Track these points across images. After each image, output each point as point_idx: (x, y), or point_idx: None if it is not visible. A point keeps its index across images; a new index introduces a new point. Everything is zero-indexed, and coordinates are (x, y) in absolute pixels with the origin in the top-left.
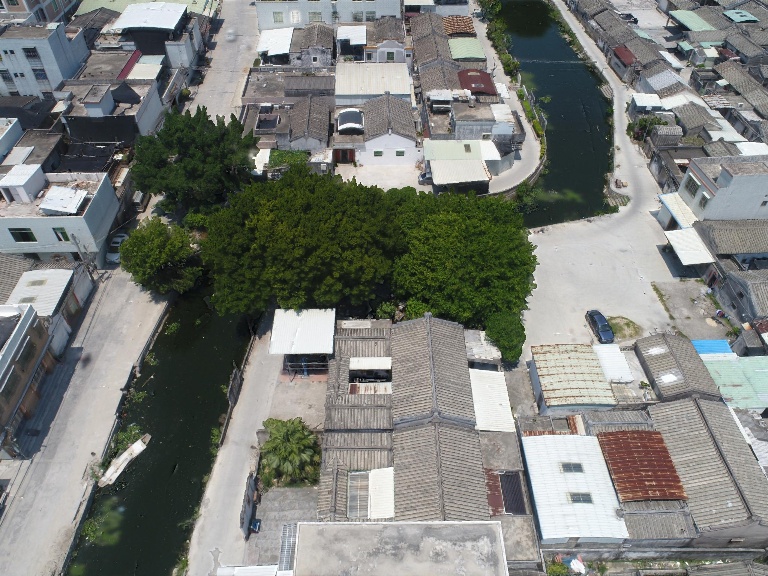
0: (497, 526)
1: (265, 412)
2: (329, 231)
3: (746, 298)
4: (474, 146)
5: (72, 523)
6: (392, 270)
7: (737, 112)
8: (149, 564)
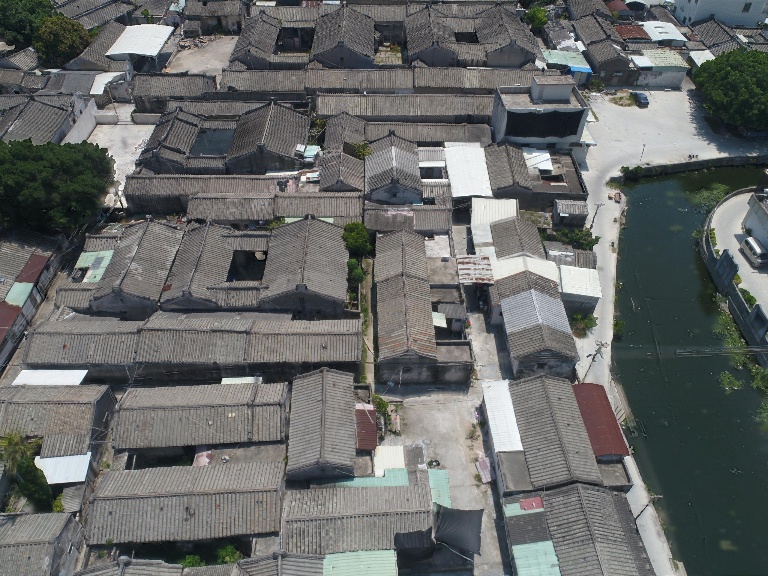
0: None
1: None
2: None
3: None
4: None
5: None
6: None
7: None
8: None
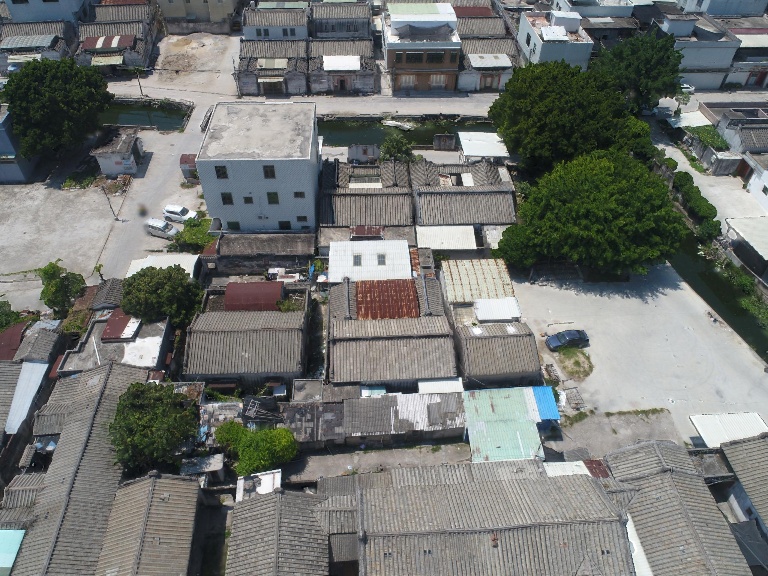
0: None
1: (433, 161)
2: (537, 94)
3: None
4: None
5: (358, 114)
6: None
7: None
8: (339, 140)
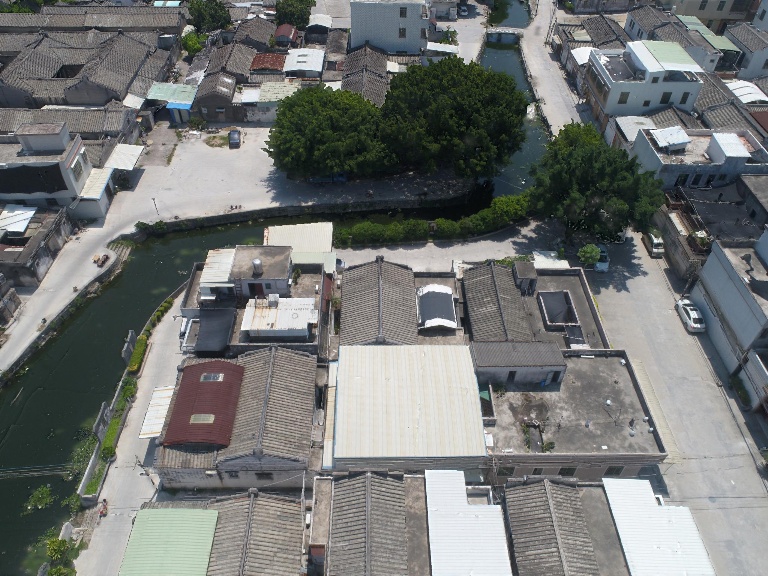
0: None
1: None
2: None
3: None
4: None
5: None
6: None
7: None
8: None
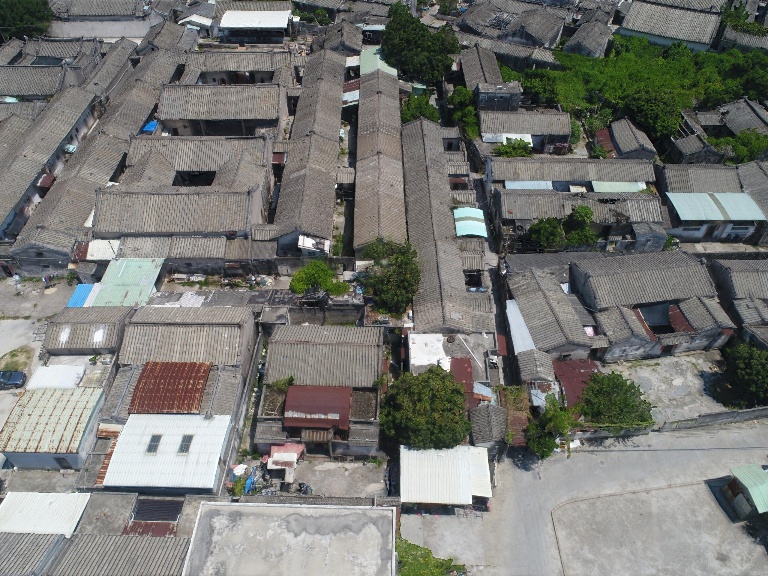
0: (205, 506)
1: None
2: None
3: (46, 252)
4: None
5: None
6: None
7: None
8: None
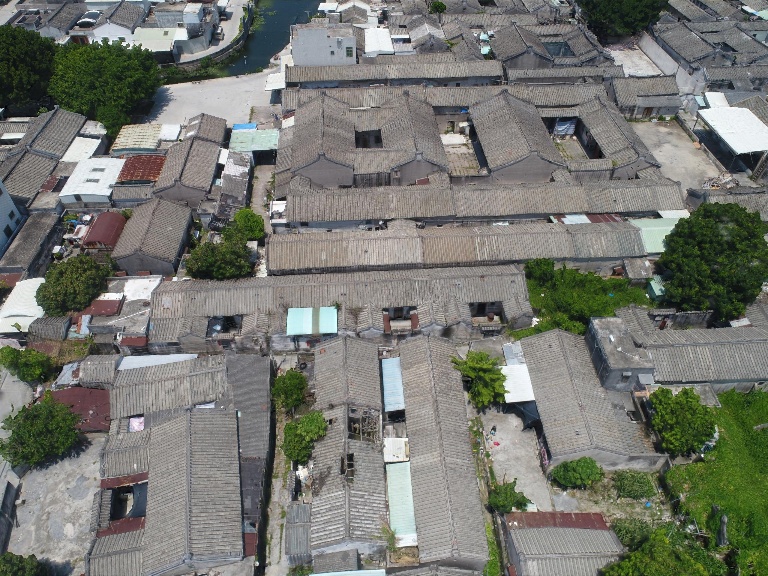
0: None
1: None
2: None
3: None
4: (171, 32)
5: None
6: (49, 87)
7: (388, 12)
8: None
